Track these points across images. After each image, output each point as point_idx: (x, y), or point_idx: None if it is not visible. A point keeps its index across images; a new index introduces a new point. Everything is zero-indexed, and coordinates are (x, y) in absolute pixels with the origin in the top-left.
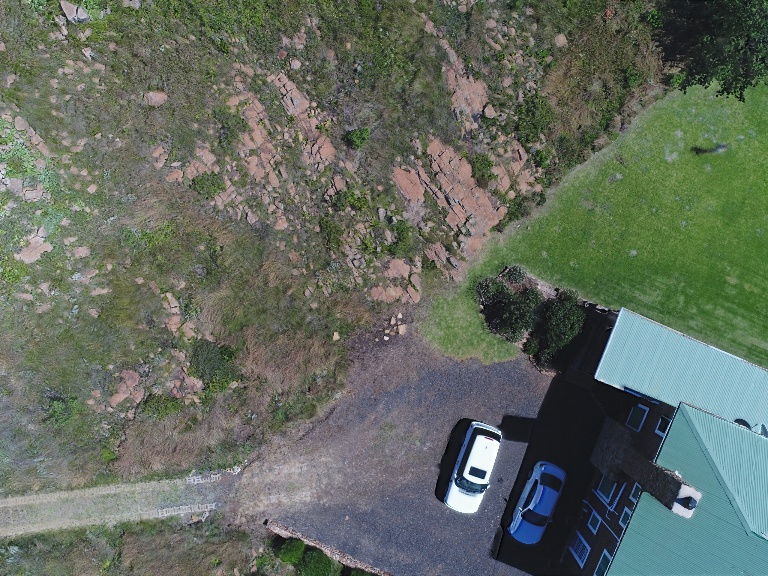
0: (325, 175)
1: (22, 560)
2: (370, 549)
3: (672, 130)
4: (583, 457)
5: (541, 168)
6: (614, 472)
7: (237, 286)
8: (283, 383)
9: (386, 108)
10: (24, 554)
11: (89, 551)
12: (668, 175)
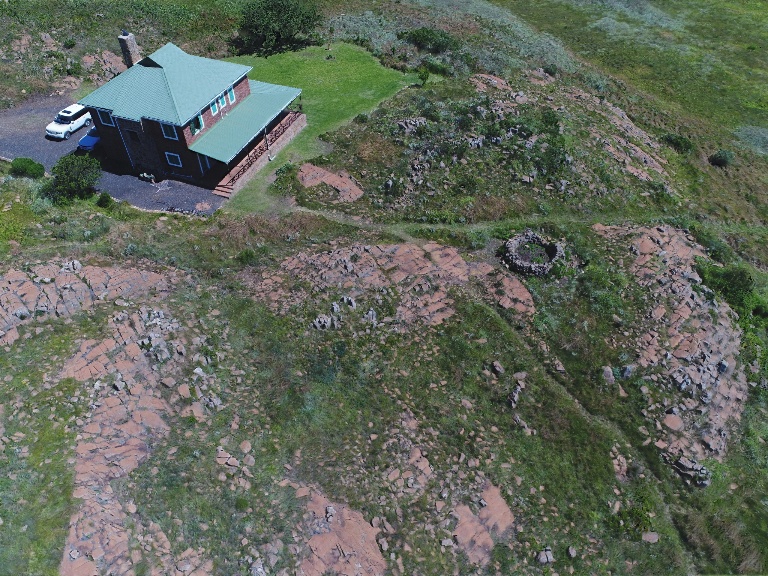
0: None
1: None
2: None
3: None
4: None
5: None
6: None
7: None
8: None
9: None
10: None
11: None
12: None
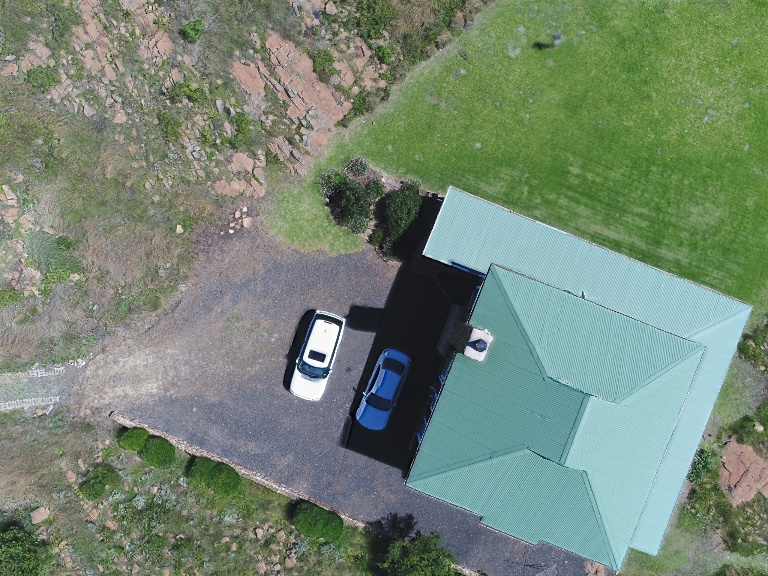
0: (163, 69)
1: None
2: (218, 440)
3: (515, 26)
4: (430, 345)
5: (386, 65)
6: (444, 346)
7: (75, 178)
8: (125, 275)
9: (223, 2)
10: None
11: None
12: (511, 70)
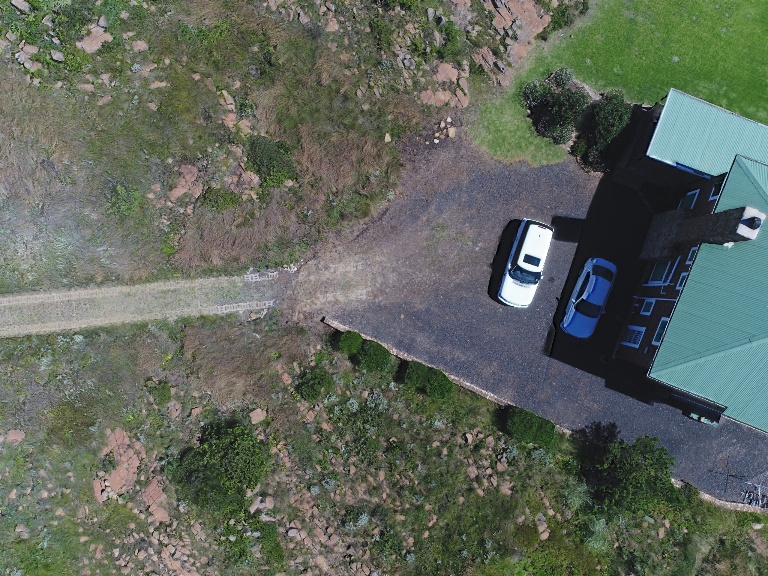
0: None
1: (87, 347)
2: (426, 347)
3: None
4: (632, 255)
5: None
6: (668, 247)
7: (291, 85)
8: (337, 181)
9: None
10: (89, 343)
11: (152, 342)
12: None
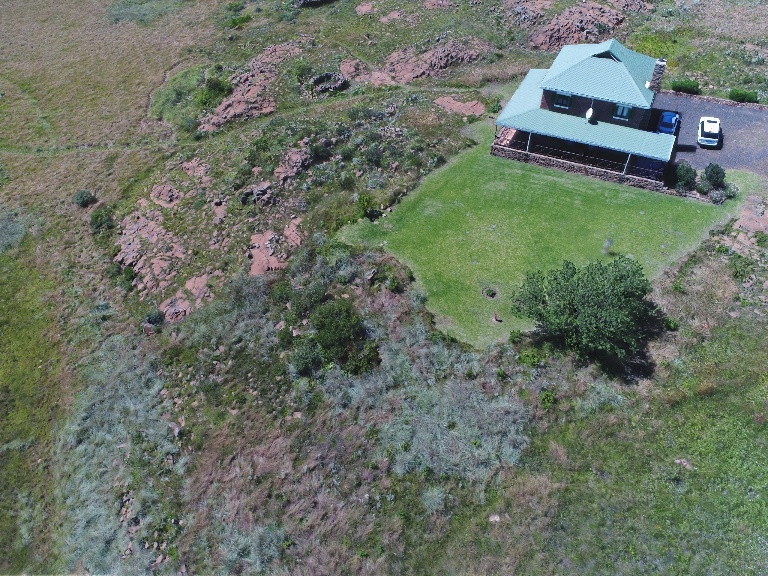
0: None
1: None
2: None
3: None
4: None
5: None
6: None
7: None
8: None
9: None
10: None
11: None
12: (629, 248)
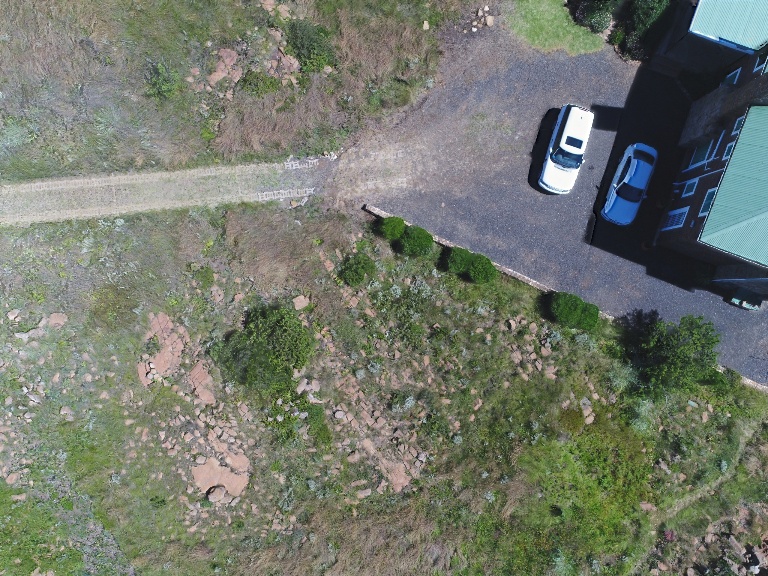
0: None
1: (129, 230)
2: (467, 235)
3: None
4: (671, 143)
5: None
6: (712, 122)
7: None
8: (377, 68)
9: None
10: (131, 226)
11: (194, 227)
12: None
